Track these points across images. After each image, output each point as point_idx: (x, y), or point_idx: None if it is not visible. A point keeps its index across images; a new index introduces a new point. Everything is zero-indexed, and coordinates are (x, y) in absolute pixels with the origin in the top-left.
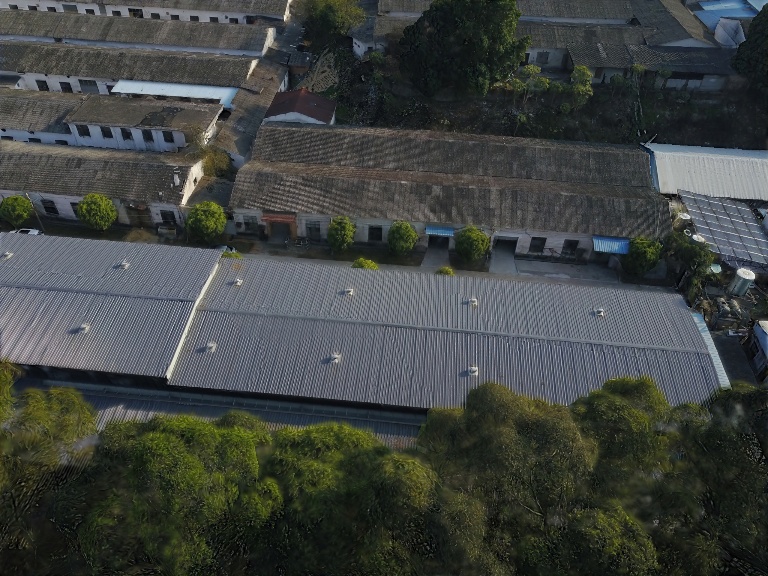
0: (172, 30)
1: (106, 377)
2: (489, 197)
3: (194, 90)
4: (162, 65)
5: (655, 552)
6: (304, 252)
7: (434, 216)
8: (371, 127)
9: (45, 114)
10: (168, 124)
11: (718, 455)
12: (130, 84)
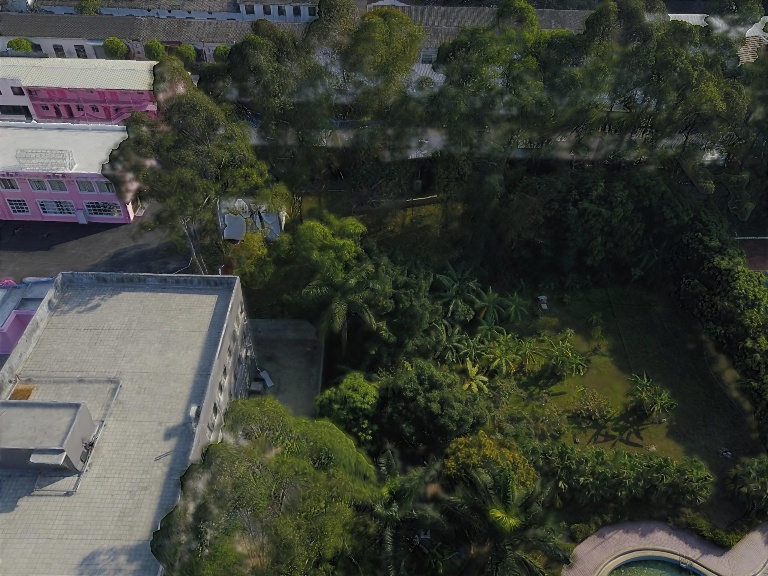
0: None
1: None
2: None
3: None
4: None
5: None
6: None
7: None
8: None
9: (218, 1)
10: (312, 2)
11: (718, 14)
12: None
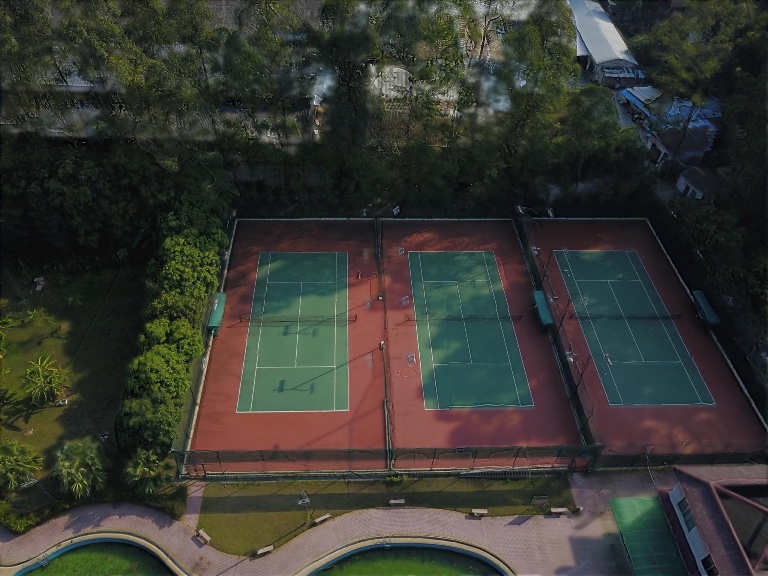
0: None
1: None
2: (219, 12)
3: None
4: None
5: (121, 13)
6: None
7: None
8: None
9: None
10: None
11: None
12: None
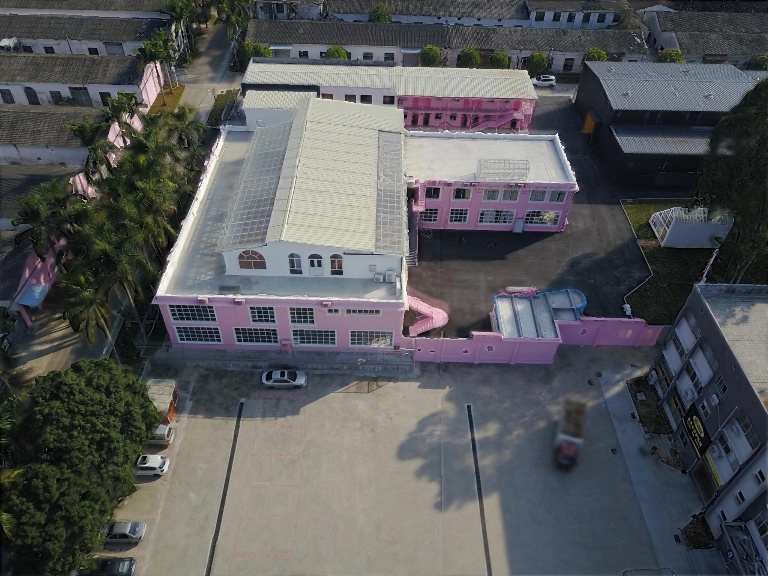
0: None
1: None
2: None
3: None
4: None
5: None
6: None
7: None
8: None
9: (505, 8)
10: (603, 9)
11: None
12: None
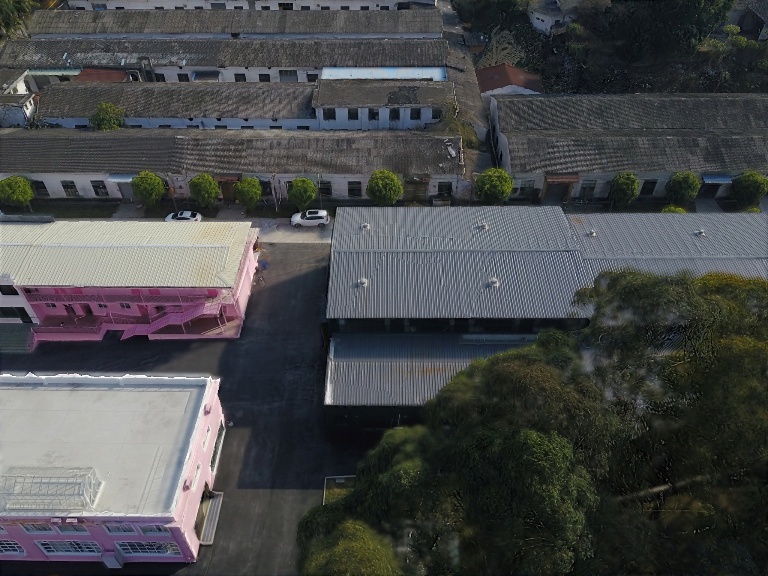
0: (348, 18)
1: (531, 325)
2: (754, 145)
3: (401, 72)
4: (361, 51)
5: None
6: (582, 211)
7: (710, 166)
8: (590, 94)
9: (284, 101)
10: (416, 101)
11: None
12: (336, 71)
